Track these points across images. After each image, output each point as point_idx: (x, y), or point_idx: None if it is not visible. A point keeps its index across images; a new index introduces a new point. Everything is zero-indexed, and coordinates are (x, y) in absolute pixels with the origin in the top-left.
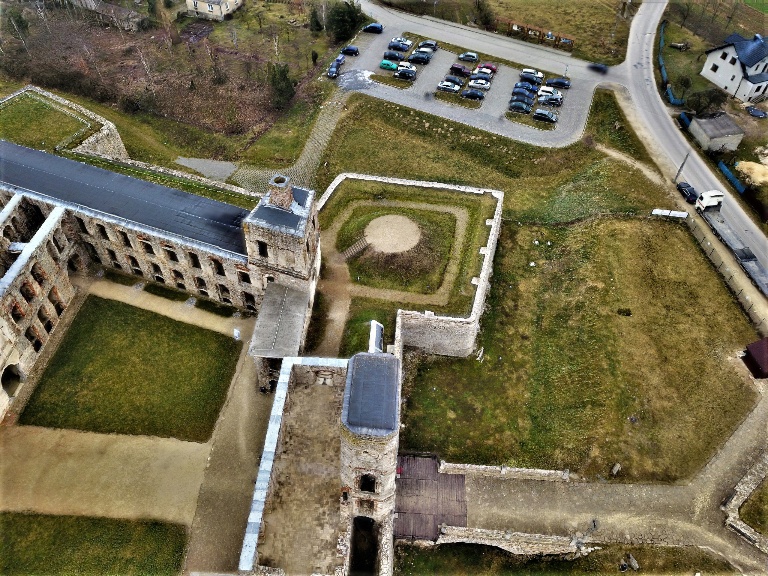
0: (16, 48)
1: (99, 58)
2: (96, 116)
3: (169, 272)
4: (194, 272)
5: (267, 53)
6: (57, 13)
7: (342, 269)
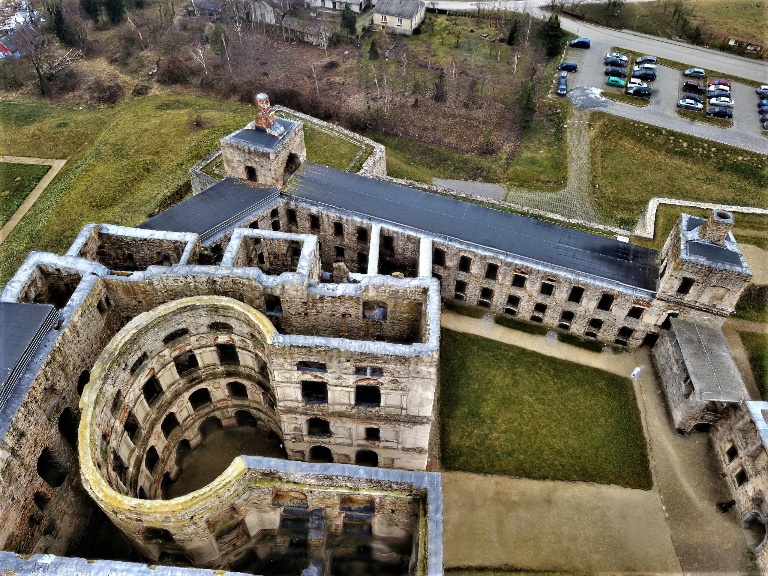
0: (212, 64)
1: (301, 74)
2: (362, 138)
3: (531, 305)
4: (568, 306)
5: (474, 69)
6: None
7: None
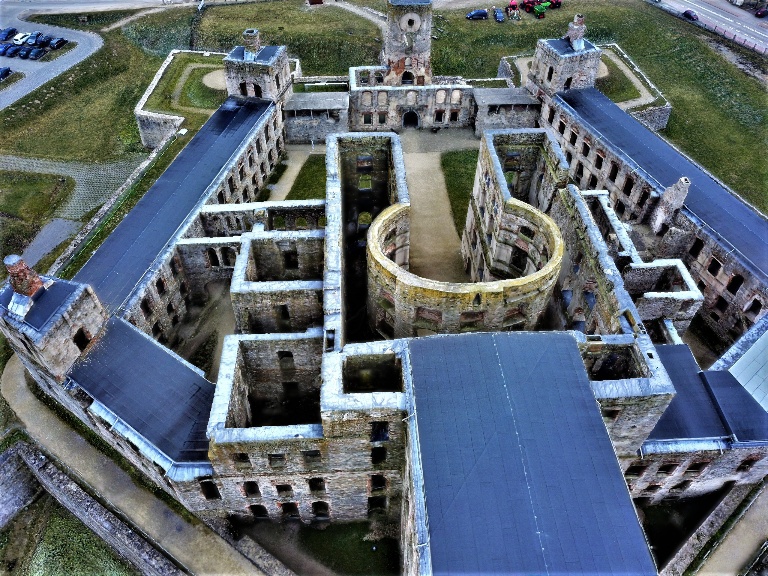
0: None
1: None
2: None
3: None
4: None
5: None
6: None
7: None
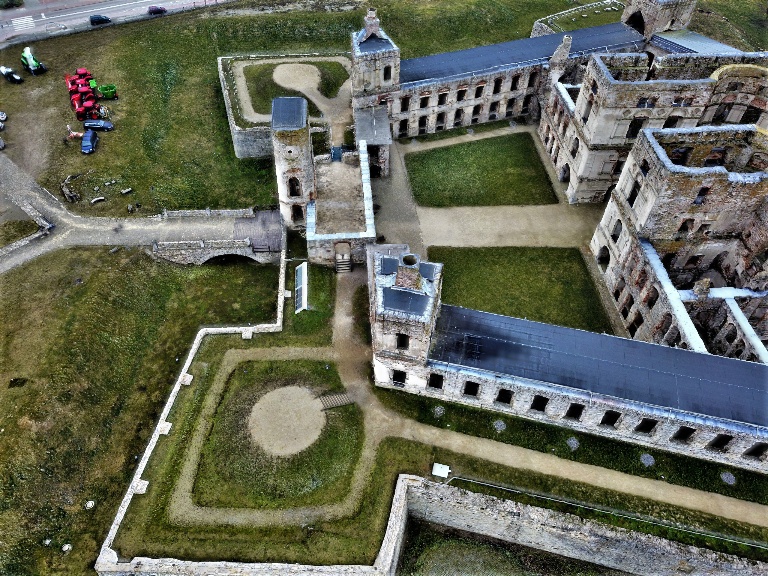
0: None
1: None
2: None
3: None
4: None
5: None
6: None
7: (349, 379)
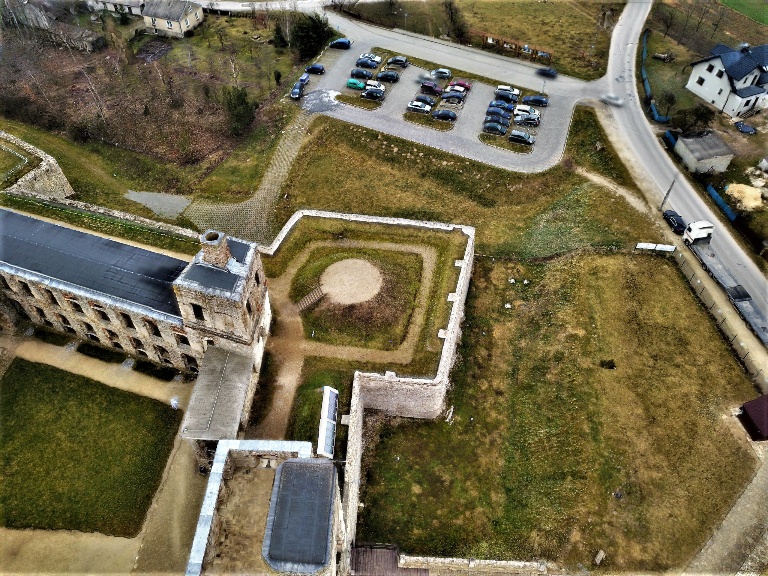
0: None
1: (50, 81)
2: (35, 150)
3: (102, 331)
4: (128, 332)
5: (228, 73)
6: (8, 33)
7: (295, 323)
